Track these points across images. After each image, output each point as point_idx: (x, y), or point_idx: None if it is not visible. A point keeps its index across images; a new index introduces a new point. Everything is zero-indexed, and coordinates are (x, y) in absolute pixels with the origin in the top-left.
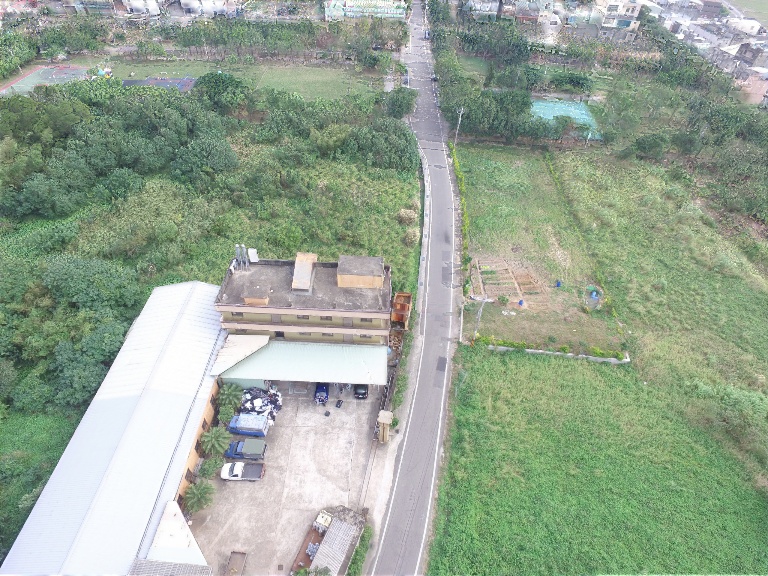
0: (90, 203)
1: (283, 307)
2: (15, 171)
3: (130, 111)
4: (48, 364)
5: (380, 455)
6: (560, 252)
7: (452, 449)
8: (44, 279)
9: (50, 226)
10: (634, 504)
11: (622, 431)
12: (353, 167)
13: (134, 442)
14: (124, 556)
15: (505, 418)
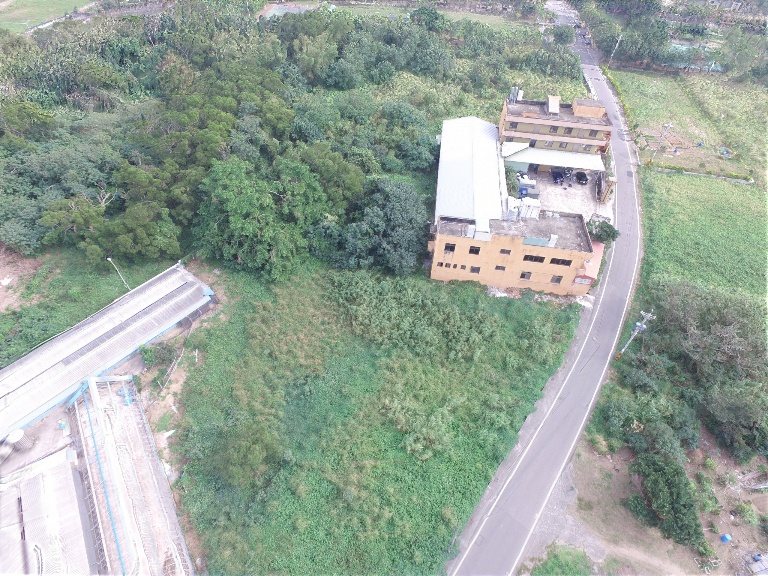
0: (366, 83)
1: (549, 119)
2: (325, 56)
3: (376, 29)
4: (395, 152)
5: (603, 207)
6: (697, 130)
7: (646, 208)
8: (385, 107)
9: (357, 89)
10: (762, 236)
11: (752, 209)
12: (535, 75)
13: (480, 173)
14: (497, 210)
15: (676, 198)
